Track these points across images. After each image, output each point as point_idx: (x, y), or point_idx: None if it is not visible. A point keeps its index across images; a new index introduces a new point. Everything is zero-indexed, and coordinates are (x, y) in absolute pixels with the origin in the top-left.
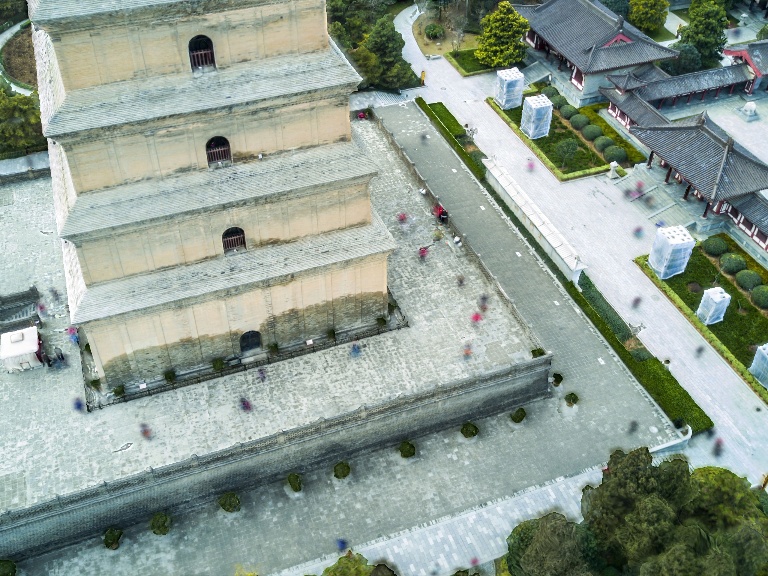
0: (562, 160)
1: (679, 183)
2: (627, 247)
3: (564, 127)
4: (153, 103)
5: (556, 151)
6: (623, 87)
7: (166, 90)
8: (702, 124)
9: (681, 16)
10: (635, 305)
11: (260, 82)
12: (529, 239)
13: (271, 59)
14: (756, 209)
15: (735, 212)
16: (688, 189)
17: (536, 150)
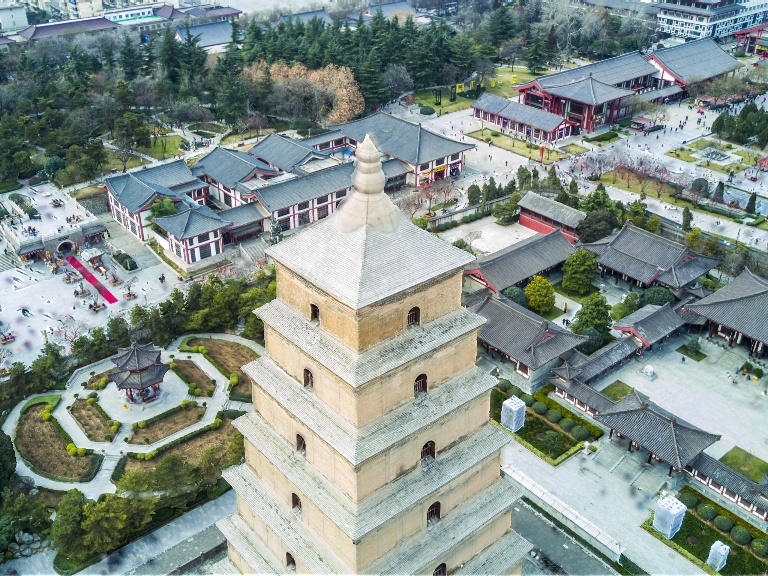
0: (546, 447)
1: (638, 449)
2: (630, 515)
3: (531, 415)
4: (411, 561)
5: (545, 444)
6: (569, 378)
7: (416, 547)
8: (646, 407)
9: (557, 291)
10: (662, 567)
11: (468, 519)
12: (566, 530)
13: (470, 499)
14: (706, 466)
15: (689, 468)
16: (651, 456)
17: (523, 442)
